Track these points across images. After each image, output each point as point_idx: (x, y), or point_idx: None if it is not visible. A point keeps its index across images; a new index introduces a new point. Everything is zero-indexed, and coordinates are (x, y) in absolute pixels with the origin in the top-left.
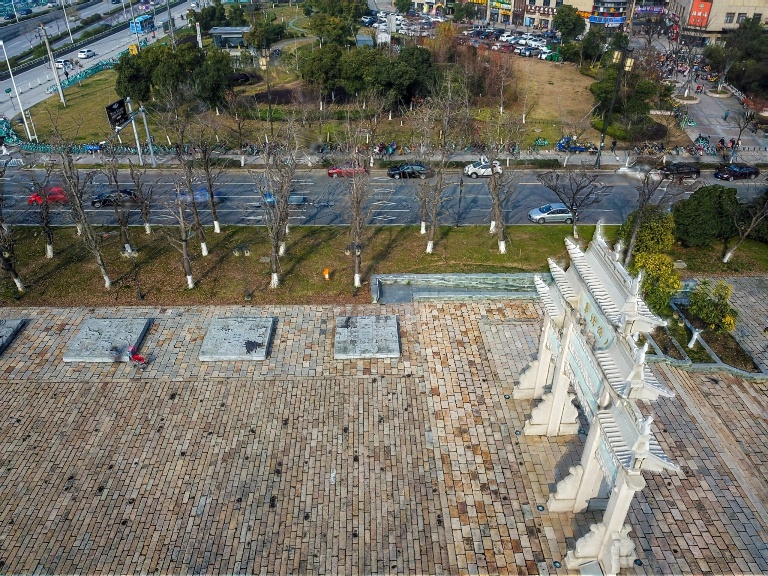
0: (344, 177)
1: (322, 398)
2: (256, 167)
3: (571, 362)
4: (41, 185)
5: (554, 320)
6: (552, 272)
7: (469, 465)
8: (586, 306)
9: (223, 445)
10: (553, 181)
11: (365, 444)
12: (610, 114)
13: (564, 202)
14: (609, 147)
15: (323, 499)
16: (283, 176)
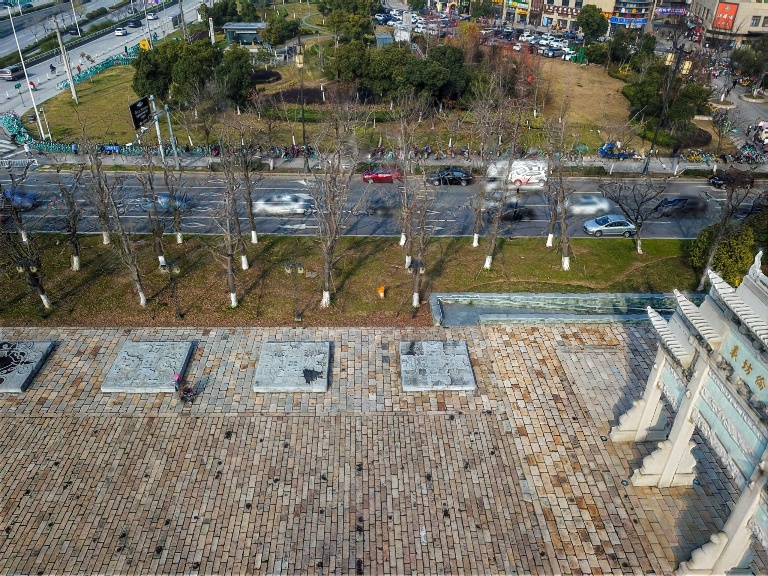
0: (381, 183)
1: (396, 438)
2: (286, 171)
3: (703, 410)
4: (69, 191)
5: (681, 360)
6: (682, 306)
7: (576, 522)
8: (734, 349)
9: (293, 495)
10: (617, 192)
11: (453, 495)
12: (660, 120)
13: (628, 215)
14: (653, 154)
15: (416, 564)
16: (336, 185)
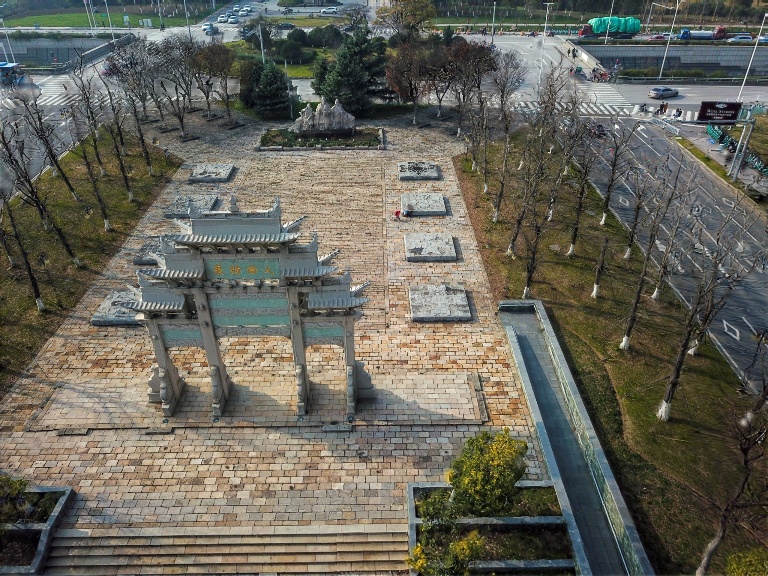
0: None
1: None
2: None
3: None
4: None
5: None
6: None
7: (281, 349)
8: None
9: None
10: None
11: None
12: None
13: None
14: None
15: None
16: None
